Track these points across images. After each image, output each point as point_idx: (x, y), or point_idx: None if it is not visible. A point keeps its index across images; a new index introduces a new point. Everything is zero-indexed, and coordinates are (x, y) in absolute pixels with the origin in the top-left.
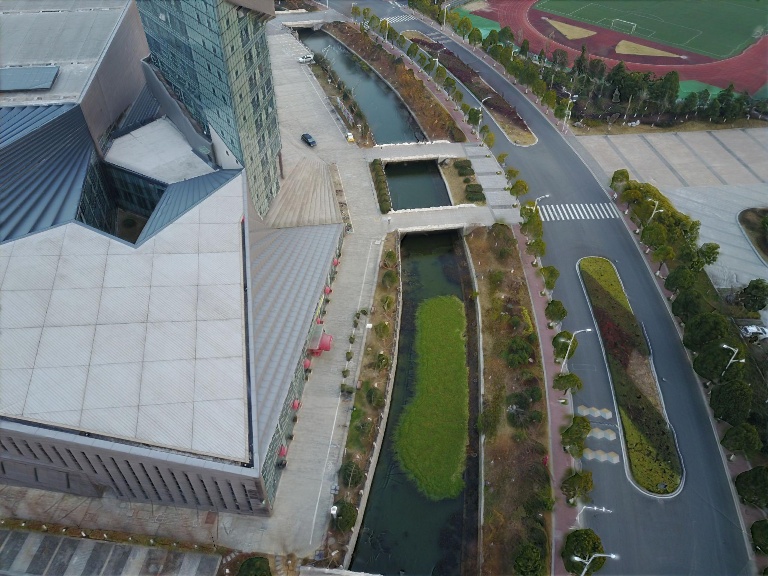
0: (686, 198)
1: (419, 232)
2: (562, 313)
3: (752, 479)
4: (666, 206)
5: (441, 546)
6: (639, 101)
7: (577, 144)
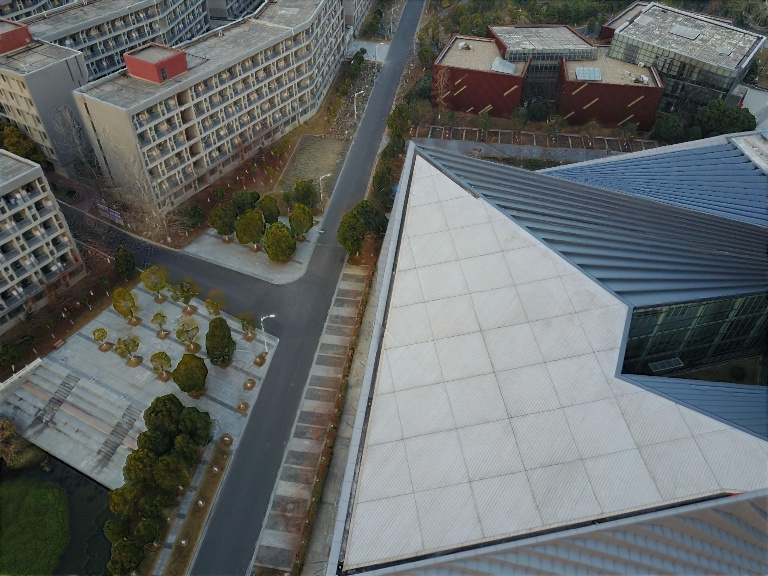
0: None
1: None
2: None
3: None
4: None
5: None
6: None
7: None
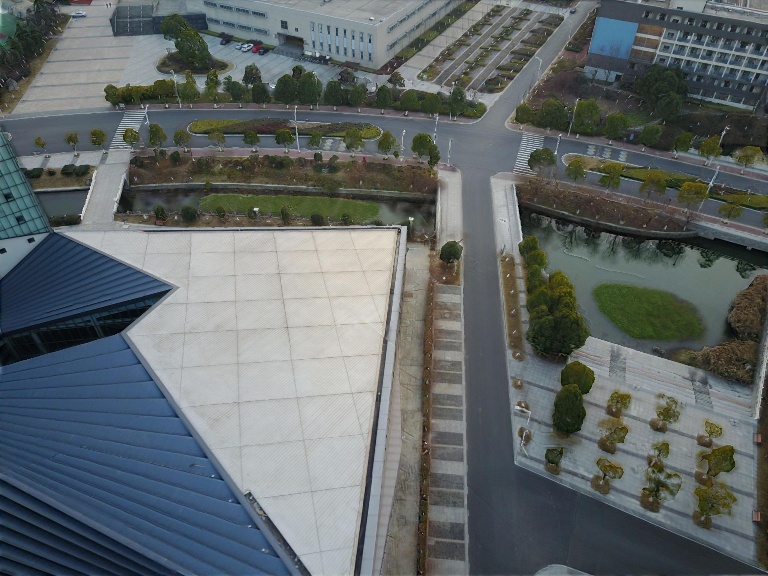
0: (133, 85)
1: None
2: (256, 135)
3: (383, 95)
4: (152, 86)
5: (410, 211)
6: None
7: (26, 115)
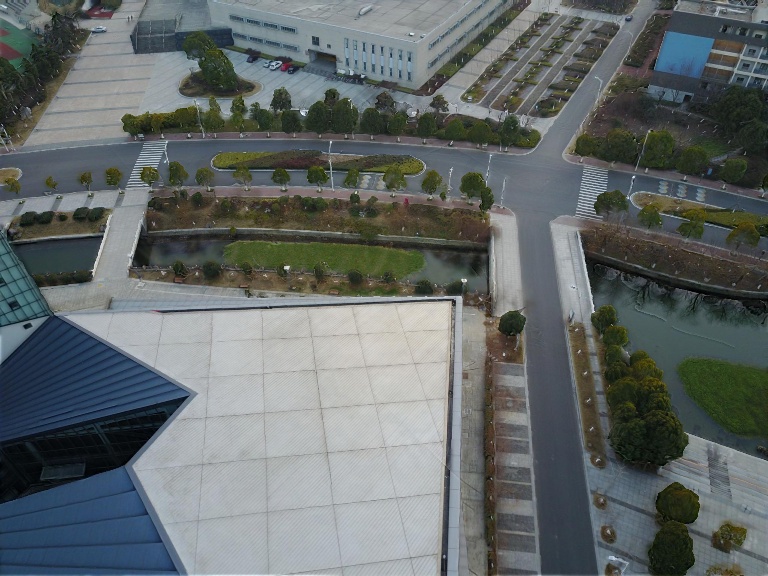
0: (154, 111)
1: (134, 256)
2: None
3: (426, 124)
4: (173, 113)
5: (459, 263)
6: (8, 94)
7: (39, 147)
